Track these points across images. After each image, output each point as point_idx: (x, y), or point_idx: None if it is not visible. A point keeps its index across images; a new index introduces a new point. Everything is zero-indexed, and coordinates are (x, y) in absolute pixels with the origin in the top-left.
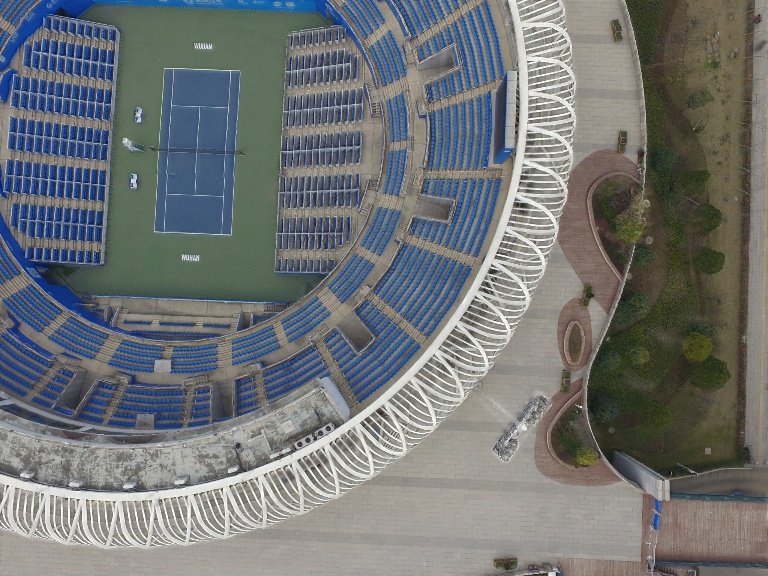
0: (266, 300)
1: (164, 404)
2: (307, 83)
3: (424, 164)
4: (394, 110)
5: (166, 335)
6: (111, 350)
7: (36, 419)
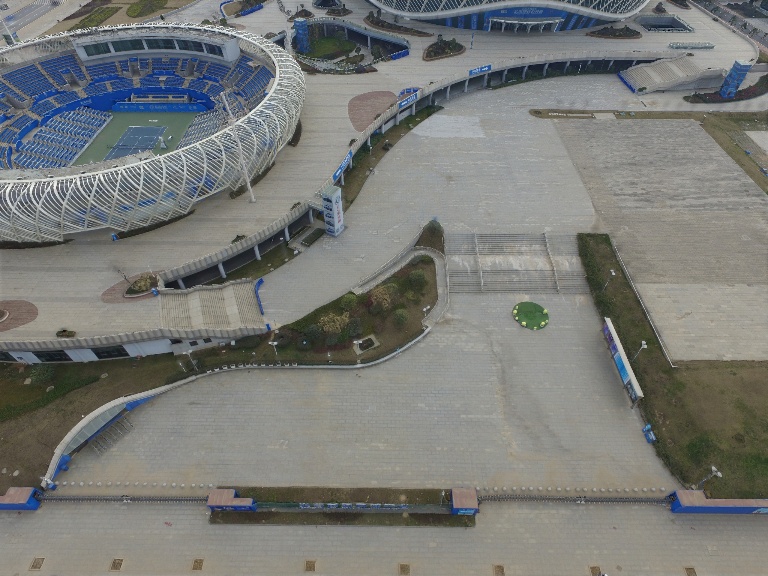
0: (123, 112)
1: (160, 67)
2: (53, 161)
3: (3, 113)
4: (8, 139)
5: (164, 92)
6: (185, 84)
7: (193, 47)
